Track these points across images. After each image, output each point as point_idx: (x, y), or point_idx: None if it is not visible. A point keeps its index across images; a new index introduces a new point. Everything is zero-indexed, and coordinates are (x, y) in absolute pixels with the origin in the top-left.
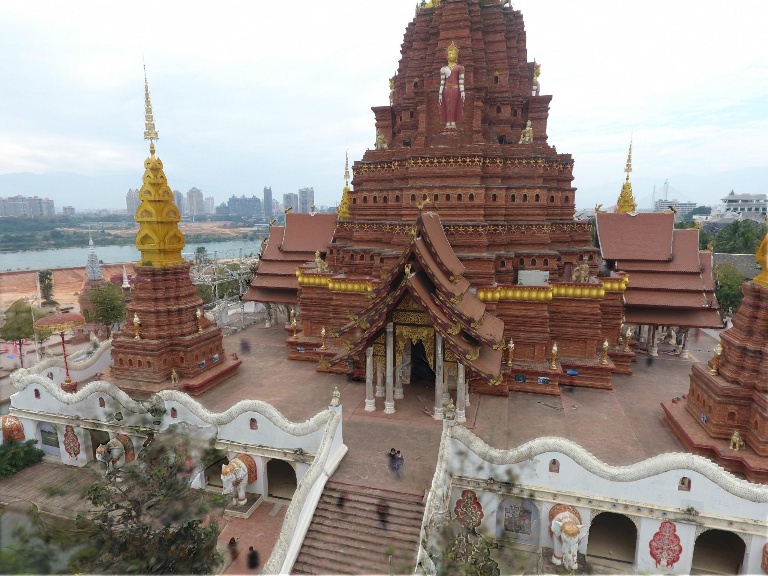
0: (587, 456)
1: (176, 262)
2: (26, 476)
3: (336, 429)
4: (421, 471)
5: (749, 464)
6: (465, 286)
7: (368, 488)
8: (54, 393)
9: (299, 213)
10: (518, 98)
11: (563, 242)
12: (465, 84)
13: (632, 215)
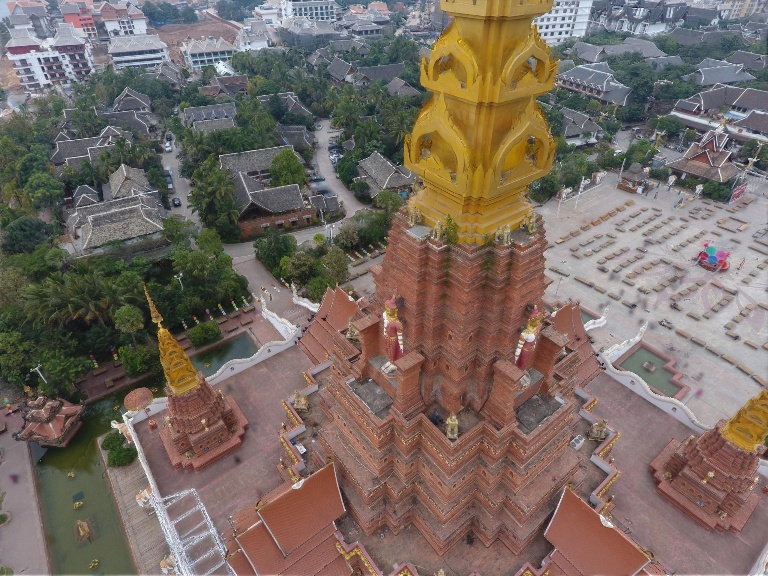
0: None
1: None
2: None
3: None
4: None
5: (738, 529)
6: None
7: None
8: None
9: (278, 498)
10: None
11: None
12: None
13: (554, 316)
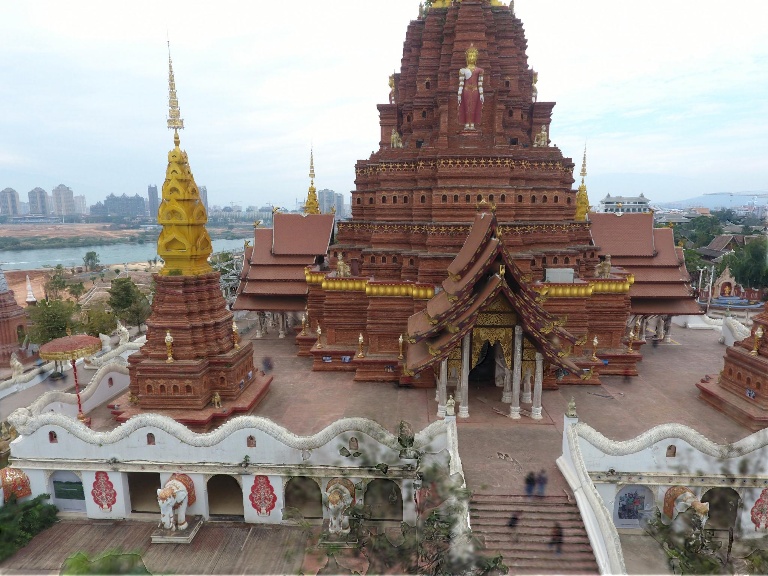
0: (701, 438)
1: (207, 270)
2: (48, 541)
3: None
4: (544, 472)
5: None
6: None
7: (509, 496)
8: (80, 434)
9: None
10: (524, 103)
11: (570, 241)
12: (483, 87)
13: (618, 215)
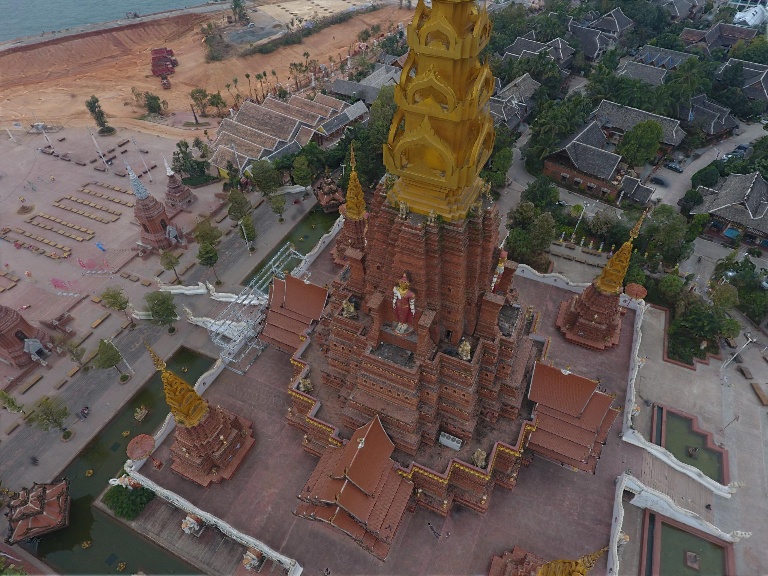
0: None
1: (200, 417)
2: (150, 510)
3: (294, 572)
4: None
5: None
6: (385, 477)
7: None
8: None
9: (295, 278)
10: (473, 295)
11: None
12: (416, 301)
13: (564, 374)
